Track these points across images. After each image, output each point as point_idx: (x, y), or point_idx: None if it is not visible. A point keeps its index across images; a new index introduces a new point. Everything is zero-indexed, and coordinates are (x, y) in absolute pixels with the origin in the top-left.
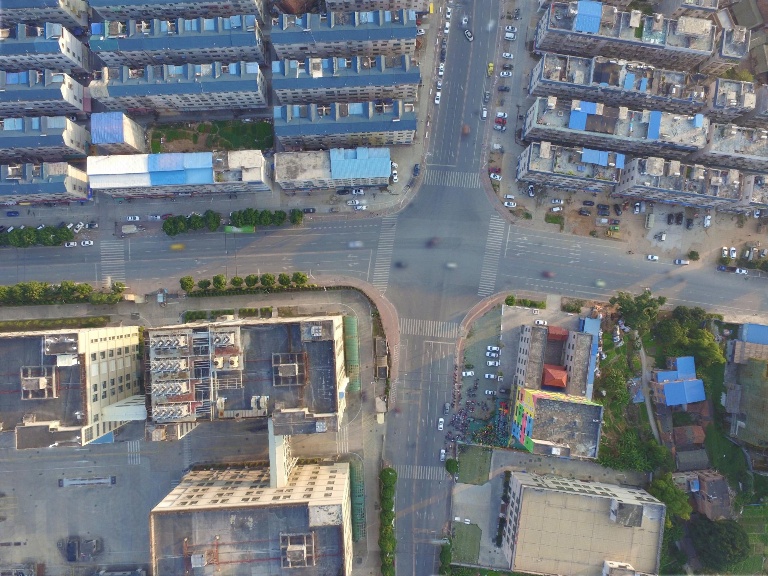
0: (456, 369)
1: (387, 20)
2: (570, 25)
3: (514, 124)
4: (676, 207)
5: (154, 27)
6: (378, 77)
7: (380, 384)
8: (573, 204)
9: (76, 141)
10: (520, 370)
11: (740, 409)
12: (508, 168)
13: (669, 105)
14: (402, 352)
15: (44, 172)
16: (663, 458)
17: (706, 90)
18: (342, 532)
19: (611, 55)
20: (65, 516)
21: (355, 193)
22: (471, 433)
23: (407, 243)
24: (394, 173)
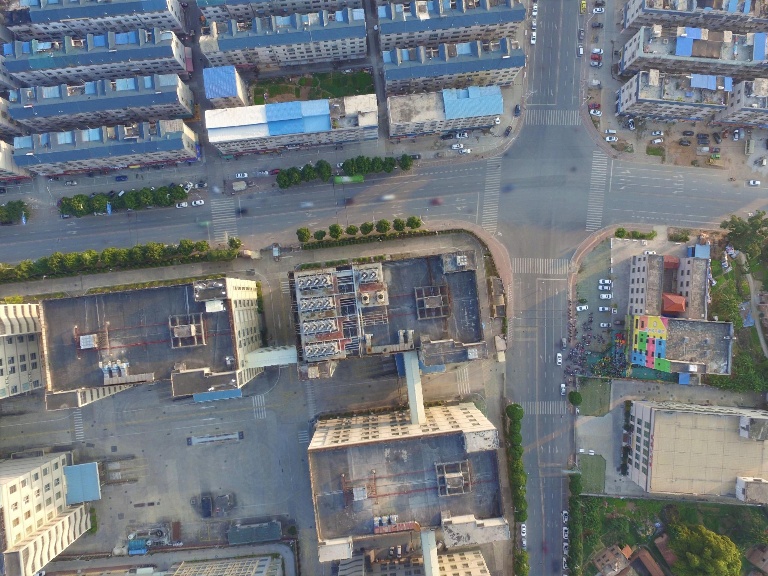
0: (570, 304)
1: None
2: None
3: (610, 60)
4: None
5: None
6: (484, 16)
7: (496, 324)
8: (673, 135)
9: (185, 99)
10: (636, 300)
11: None
12: (607, 103)
13: (767, 28)
14: (516, 291)
15: (161, 130)
16: None
17: None
18: None
19: None
20: (196, 474)
21: (459, 137)
22: (589, 366)
23: (513, 183)
24: None
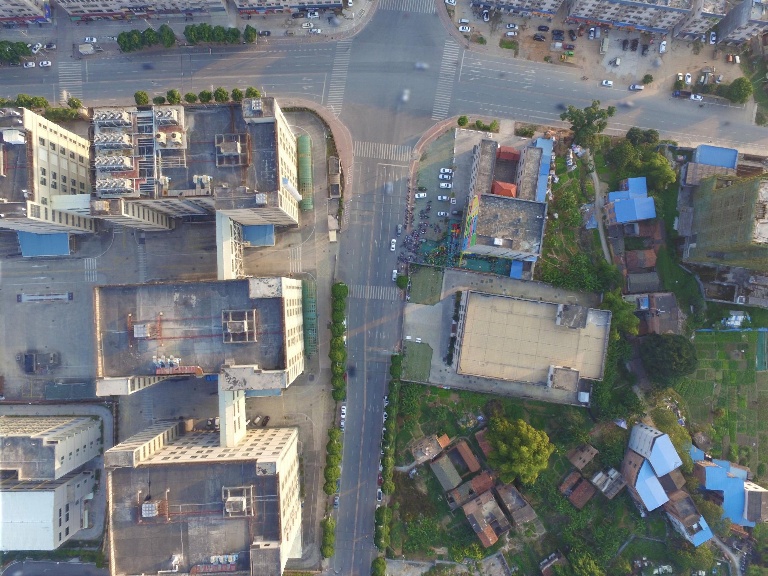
0: (409, 191)
1: None
2: None
3: None
4: (632, 33)
5: None
6: None
7: (333, 205)
8: (528, 30)
9: None
10: (471, 188)
11: (692, 231)
12: None
13: None
14: (356, 174)
15: None
16: (612, 274)
17: None
18: (282, 306)
19: None
20: (23, 330)
21: (310, 16)
22: (423, 254)
23: (361, 67)
24: None
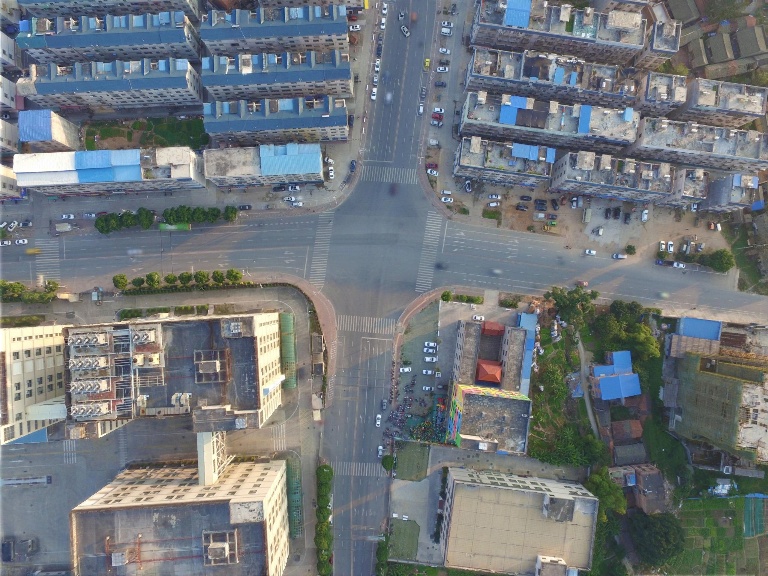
0: (393, 365)
1: (317, 16)
2: (501, 20)
3: (451, 119)
4: (614, 201)
5: (82, 24)
6: (308, 73)
7: (317, 381)
8: (511, 199)
9: (6, 139)
10: (456, 366)
11: (677, 403)
12: (445, 164)
13: (602, 99)
14: (339, 349)
15: None
16: (599, 452)
17: (637, 84)
18: (264, 529)
19: (545, 50)
20: (0, 516)
21: (291, 190)
22: (409, 429)
23: (344, 239)
24: (330, 169)
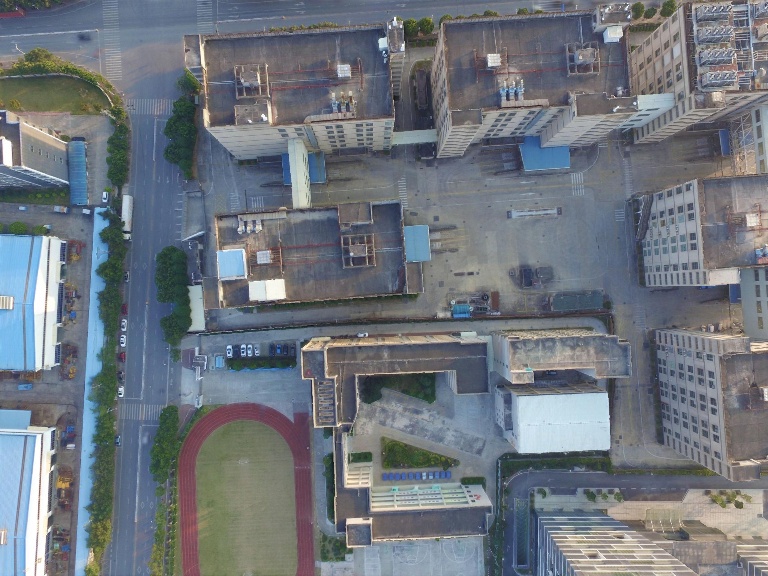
0: None
1: None
2: None
3: None
4: None
5: None
6: None
7: None
8: None
9: None
10: None
11: None
12: None
13: None
14: None
15: None
16: None
17: None
18: None
19: None
20: (515, 246)
21: None
22: None
23: None
24: None
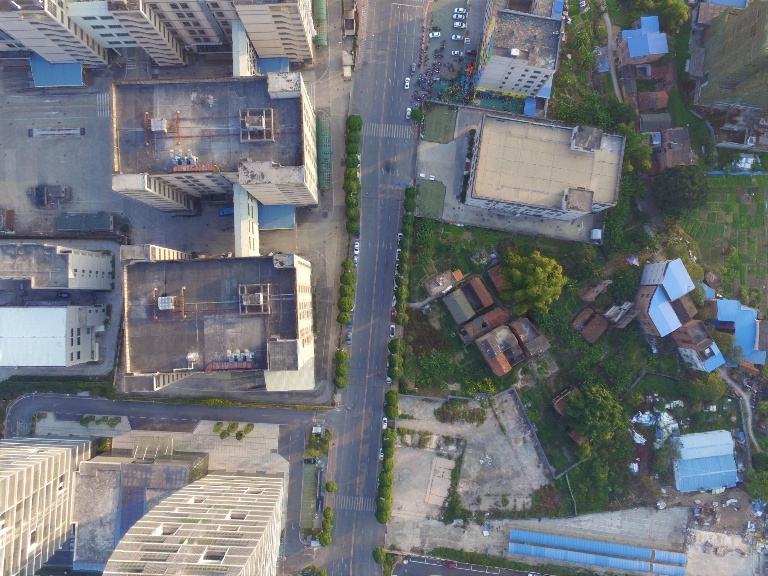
0: (423, 31)
1: None
2: None
3: None
4: None
5: None
6: None
7: (348, 44)
8: None
9: None
10: (485, 24)
11: (703, 70)
12: None
13: None
14: (370, 14)
15: None
16: (625, 108)
17: None
18: (300, 102)
19: None
20: (34, 165)
21: None
22: (437, 93)
23: None
24: None
